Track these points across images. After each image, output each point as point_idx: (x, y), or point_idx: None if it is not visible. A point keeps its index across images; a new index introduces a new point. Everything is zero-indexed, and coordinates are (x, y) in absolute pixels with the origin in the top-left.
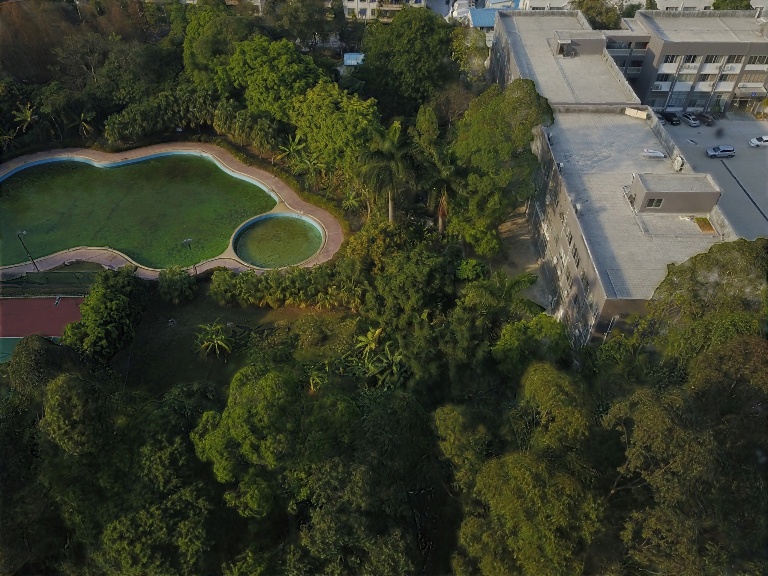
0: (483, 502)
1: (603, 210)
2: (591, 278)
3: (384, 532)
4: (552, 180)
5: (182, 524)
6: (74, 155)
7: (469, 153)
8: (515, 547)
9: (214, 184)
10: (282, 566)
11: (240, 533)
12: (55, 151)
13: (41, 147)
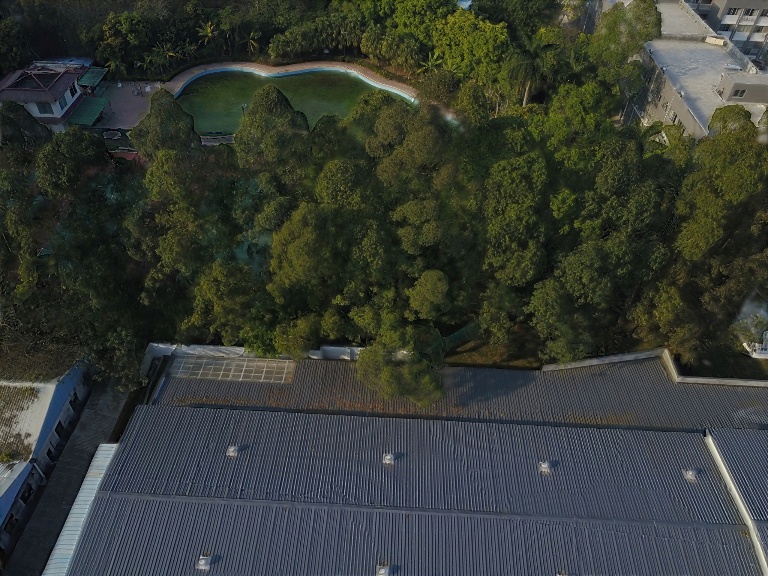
0: (700, 163)
1: (699, 99)
2: (697, 136)
3: (641, 182)
4: (655, 82)
5: (535, 166)
6: (243, 66)
7: (600, 51)
8: (720, 183)
9: (363, 92)
10: (582, 199)
11: (556, 184)
12: (226, 63)
13: (215, 59)
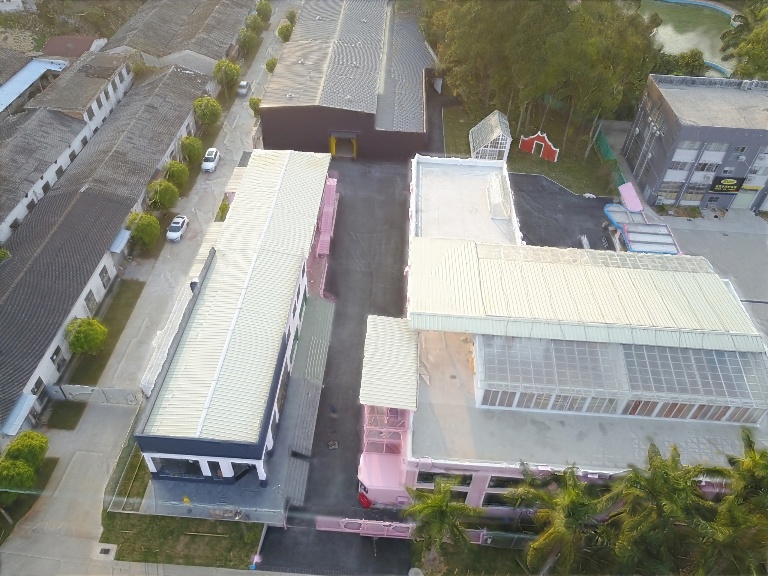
0: None
1: (759, 100)
2: None
3: None
4: None
5: None
6: None
7: None
8: None
9: None
10: None
11: None
12: (734, 10)
13: (733, 4)
